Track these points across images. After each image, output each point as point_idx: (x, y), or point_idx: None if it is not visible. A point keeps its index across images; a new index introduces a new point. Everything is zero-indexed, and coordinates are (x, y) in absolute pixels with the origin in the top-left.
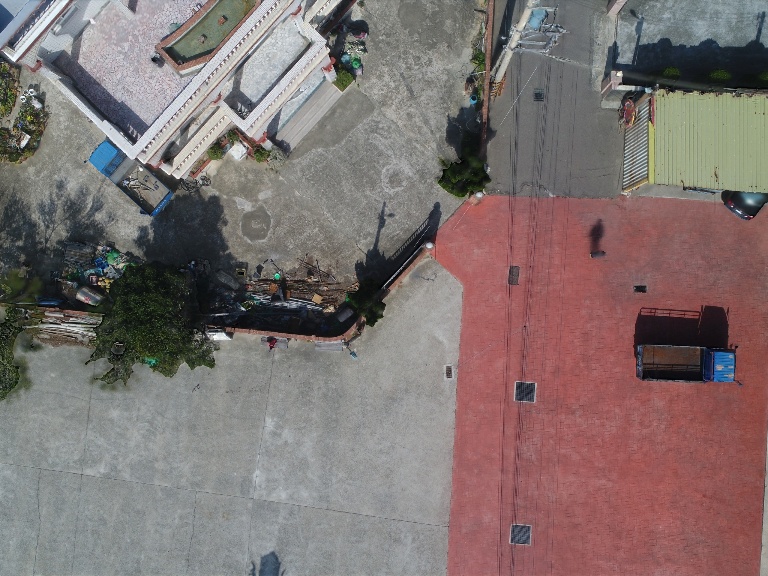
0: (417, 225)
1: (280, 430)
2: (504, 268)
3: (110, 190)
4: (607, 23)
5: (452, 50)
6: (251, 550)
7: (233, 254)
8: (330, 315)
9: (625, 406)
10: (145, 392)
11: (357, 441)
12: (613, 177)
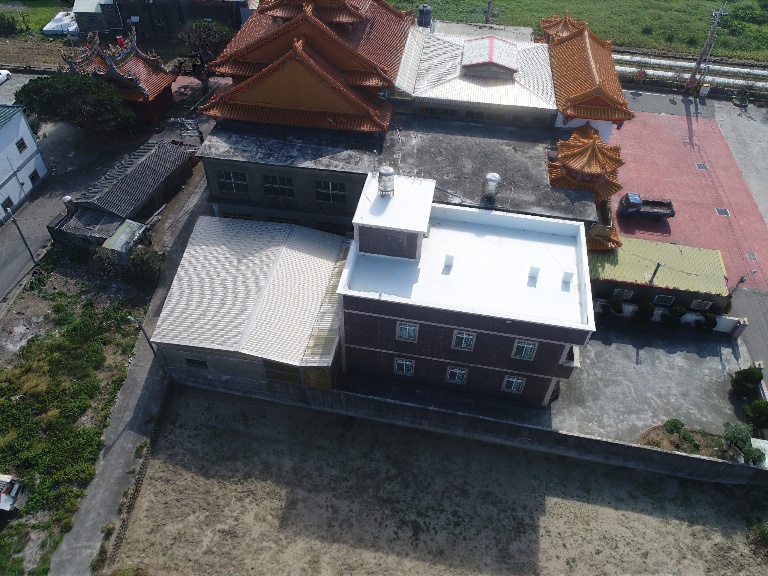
0: None
1: None
2: (760, 260)
3: None
4: None
5: None
6: None
7: None
8: None
9: None
10: None
11: None
12: None
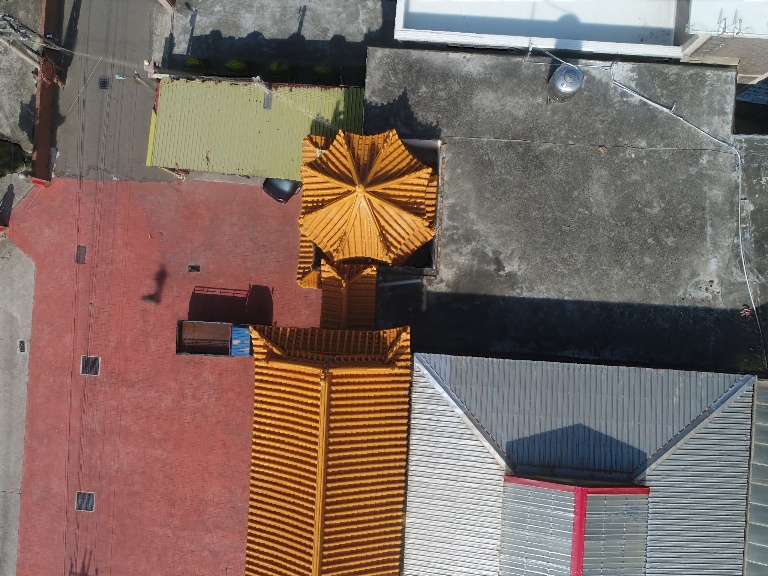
0: None
1: None
2: (72, 248)
3: None
4: (164, 15)
5: None
6: None
7: None
8: None
9: (179, 380)
10: None
11: None
12: None
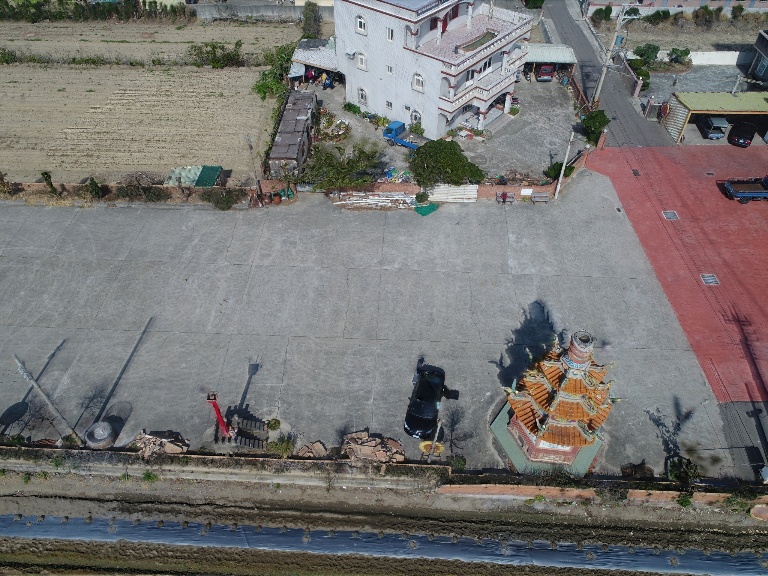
0: (572, 157)
1: (520, 240)
2: (629, 170)
3: (390, 151)
4: (635, 99)
5: (563, 107)
6: (519, 301)
7: None
8: None
9: (735, 217)
10: (422, 228)
11: (574, 242)
12: (668, 140)
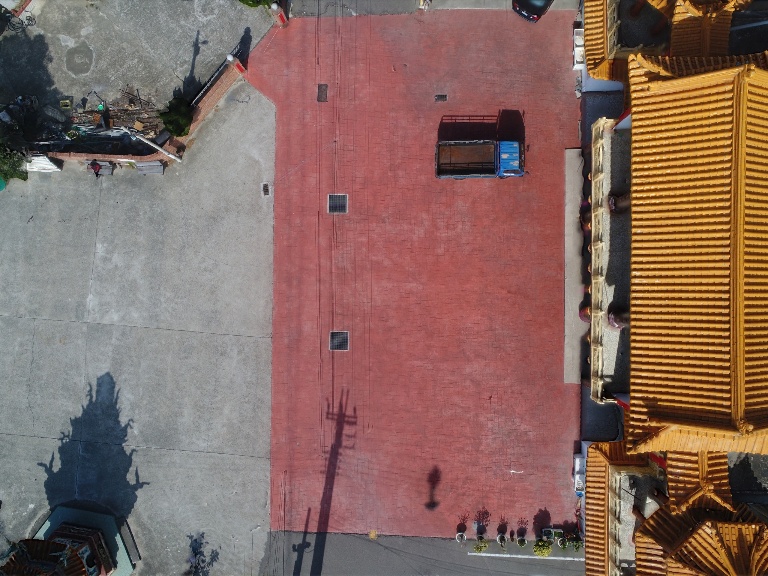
0: (229, 50)
1: (110, 255)
2: (313, 86)
3: None
4: None
5: None
6: (87, 372)
7: (59, 89)
8: (151, 141)
9: (431, 211)
10: None
11: (182, 261)
12: None
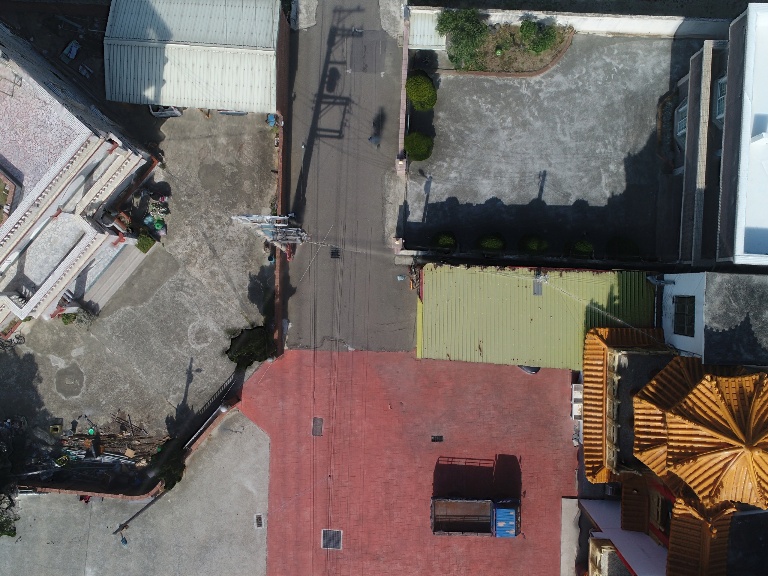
0: (223, 380)
1: None
2: (308, 420)
3: None
4: (397, 182)
5: (251, 210)
6: None
7: (48, 410)
8: (143, 468)
9: (426, 552)
10: None
11: None
12: (408, 331)
